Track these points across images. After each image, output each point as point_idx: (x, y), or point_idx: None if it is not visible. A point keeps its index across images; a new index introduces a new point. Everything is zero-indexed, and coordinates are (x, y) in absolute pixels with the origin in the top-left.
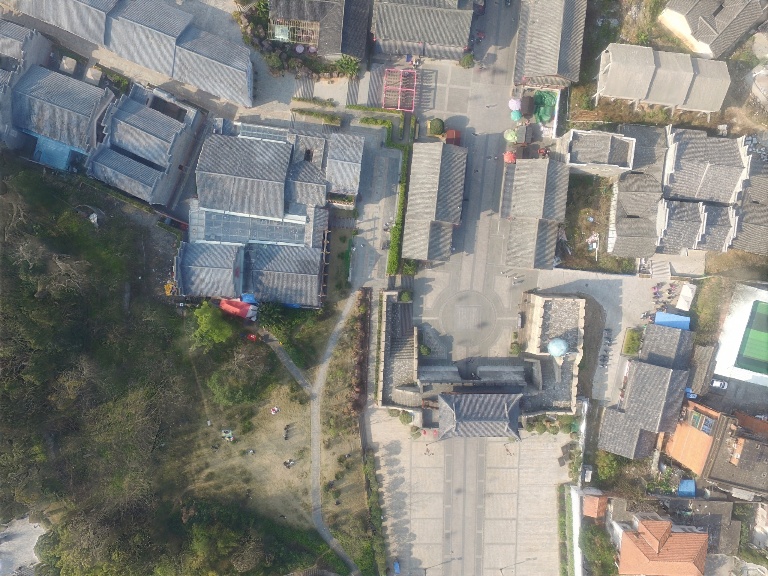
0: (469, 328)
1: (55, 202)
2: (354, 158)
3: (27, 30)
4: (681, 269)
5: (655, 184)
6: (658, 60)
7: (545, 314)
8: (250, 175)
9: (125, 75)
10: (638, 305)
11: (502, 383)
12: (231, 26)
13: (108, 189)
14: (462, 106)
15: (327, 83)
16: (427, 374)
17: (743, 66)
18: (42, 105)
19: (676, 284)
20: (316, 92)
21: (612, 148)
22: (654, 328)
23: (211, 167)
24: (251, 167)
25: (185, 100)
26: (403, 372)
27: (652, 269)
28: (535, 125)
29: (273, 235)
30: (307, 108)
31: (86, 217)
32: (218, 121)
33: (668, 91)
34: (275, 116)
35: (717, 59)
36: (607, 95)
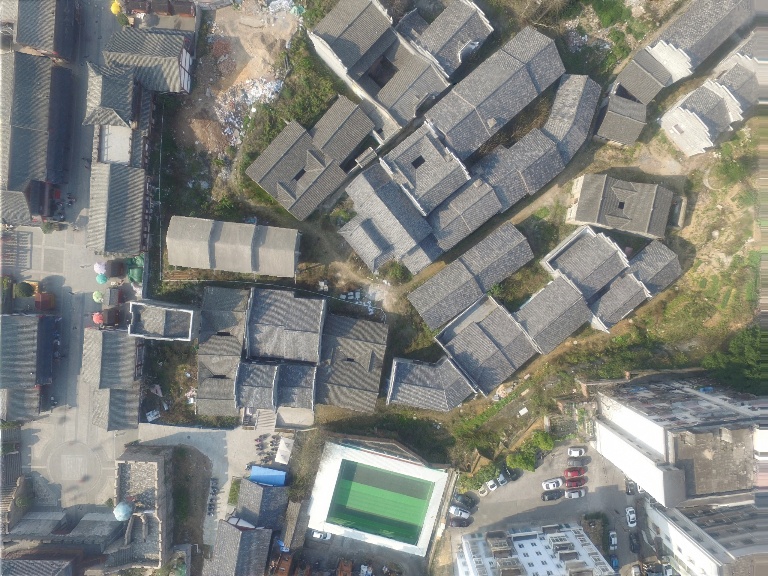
0: (76, 477)
1: None
2: None
3: None
4: (290, 419)
5: (235, 347)
6: (219, 232)
7: (125, 473)
8: None
9: None
10: (244, 455)
11: (78, 541)
12: None
13: None
14: (57, 266)
15: None
16: (25, 525)
17: (345, 222)
18: None
19: (281, 436)
20: None
21: (169, 320)
22: (246, 483)
23: None
24: None
25: None
26: (0, 523)
27: (258, 420)
28: (129, 284)
29: None
30: None
31: None
32: None
33: (232, 261)
34: None
35: (318, 215)
36: (174, 265)
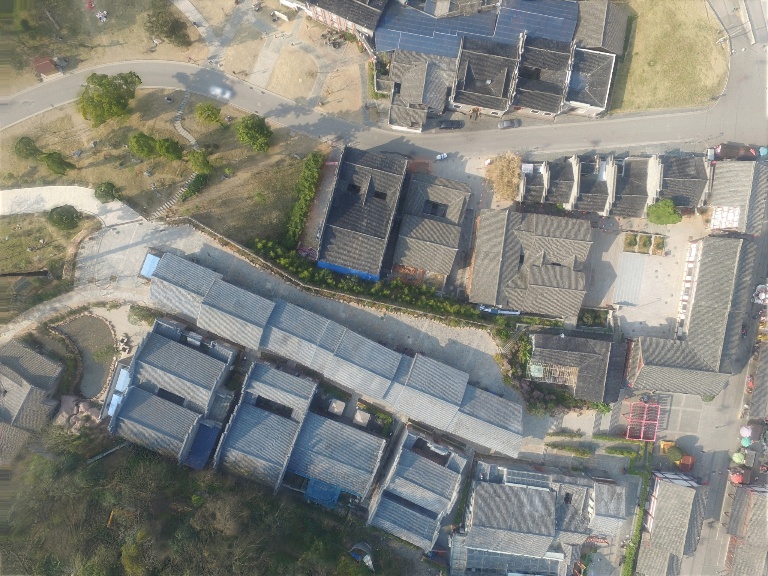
0: None
1: (333, 548)
2: (618, 512)
3: (305, 382)
4: None
5: None
6: None
7: None
8: (522, 529)
9: (387, 410)
10: None
11: None
12: (492, 367)
13: (378, 529)
14: (693, 427)
15: (576, 416)
16: None
17: None
18: (323, 460)
19: None
20: (565, 423)
21: None
22: None
23: (485, 521)
24: (522, 520)
25: (444, 434)
26: None
27: None
28: (758, 443)
29: (529, 567)
30: (558, 441)
31: (361, 561)
32: (484, 466)
33: None
34: (529, 450)
35: None
36: None
